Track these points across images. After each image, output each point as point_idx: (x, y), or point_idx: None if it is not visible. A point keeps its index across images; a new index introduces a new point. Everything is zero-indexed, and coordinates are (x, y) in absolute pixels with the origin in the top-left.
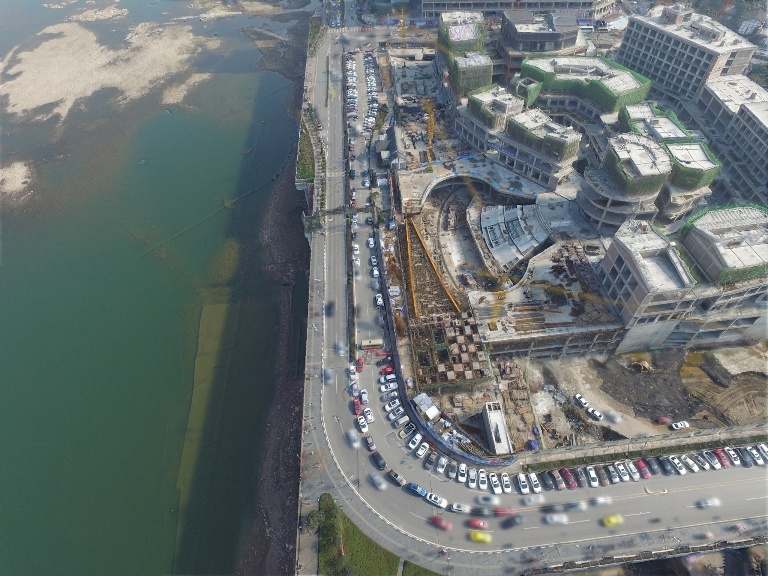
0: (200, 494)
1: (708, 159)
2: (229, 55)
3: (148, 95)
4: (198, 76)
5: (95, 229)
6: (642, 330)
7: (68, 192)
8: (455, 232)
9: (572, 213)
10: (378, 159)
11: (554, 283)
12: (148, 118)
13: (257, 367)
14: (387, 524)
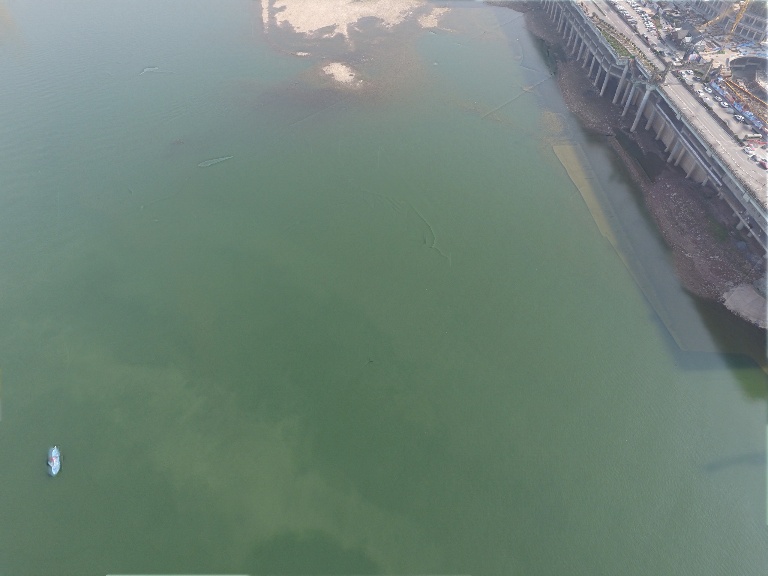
0: (624, 239)
1: None
2: None
3: (406, 22)
4: (439, 9)
5: (430, 103)
6: None
7: (391, 81)
8: None
9: None
10: (677, 45)
11: None
12: (418, 36)
13: (618, 179)
14: None
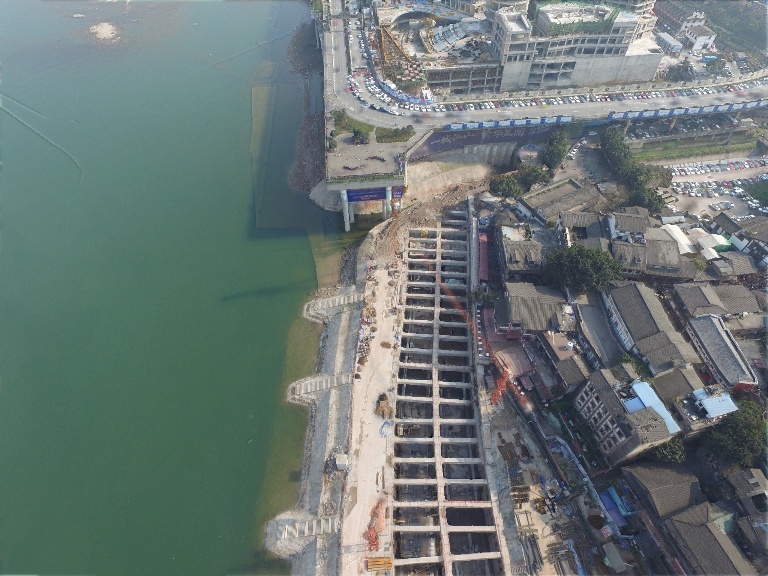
0: (264, 154)
1: None
2: None
3: None
4: None
5: (171, 56)
6: (512, 69)
7: (146, 38)
8: (412, 43)
9: (482, 24)
10: (364, 2)
11: None
12: (193, 1)
13: (290, 111)
14: (369, 118)
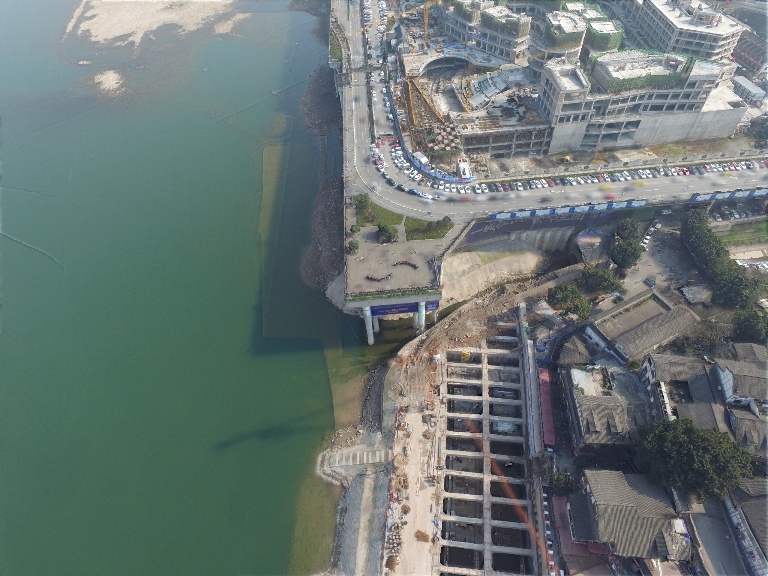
0: (274, 234)
1: (616, 29)
2: (264, 1)
3: (202, 28)
4: (241, 15)
5: (177, 109)
6: (563, 130)
7: (152, 88)
8: (443, 94)
9: (525, 73)
10: (388, 47)
11: (508, 107)
12: (205, 43)
13: (305, 177)
14: (396, 204)
